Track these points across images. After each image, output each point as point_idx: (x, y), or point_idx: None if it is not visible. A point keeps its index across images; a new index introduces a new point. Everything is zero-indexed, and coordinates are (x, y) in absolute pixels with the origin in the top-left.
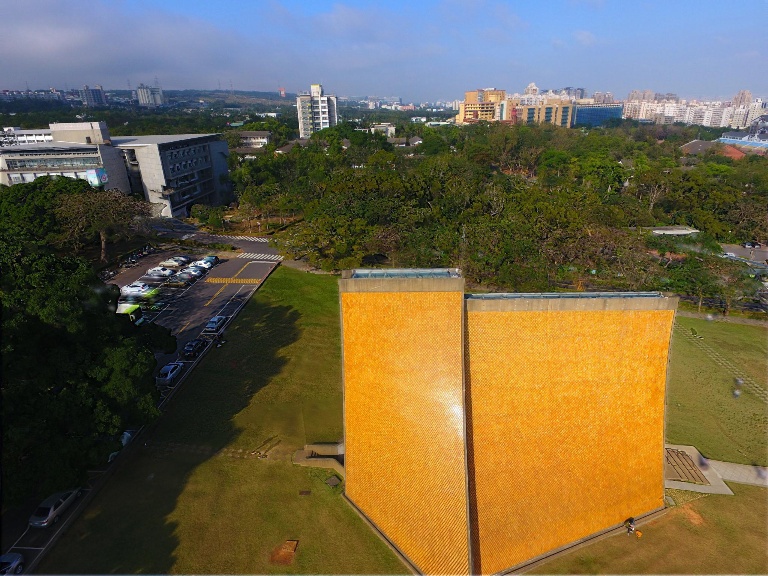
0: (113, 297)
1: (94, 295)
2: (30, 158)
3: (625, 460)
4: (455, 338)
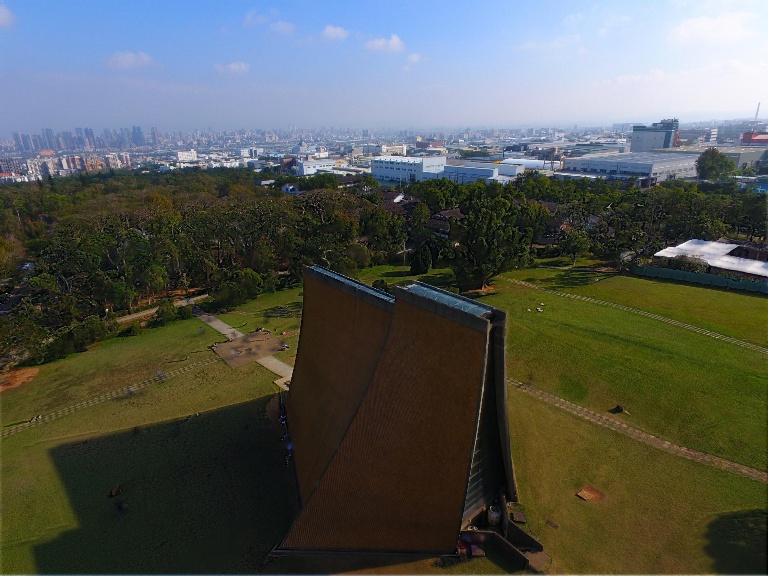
0: None
1: None
2: None
3: None
4: None
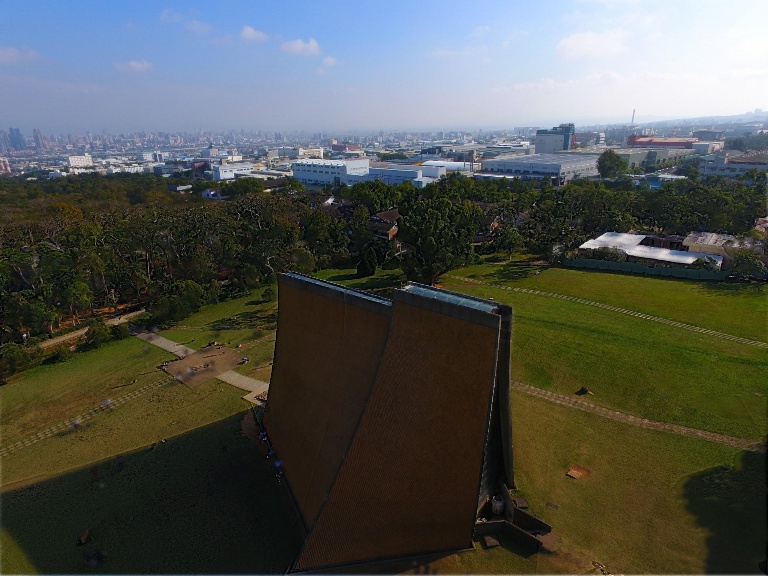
0: None
1: None
2: None
3: None
4: None
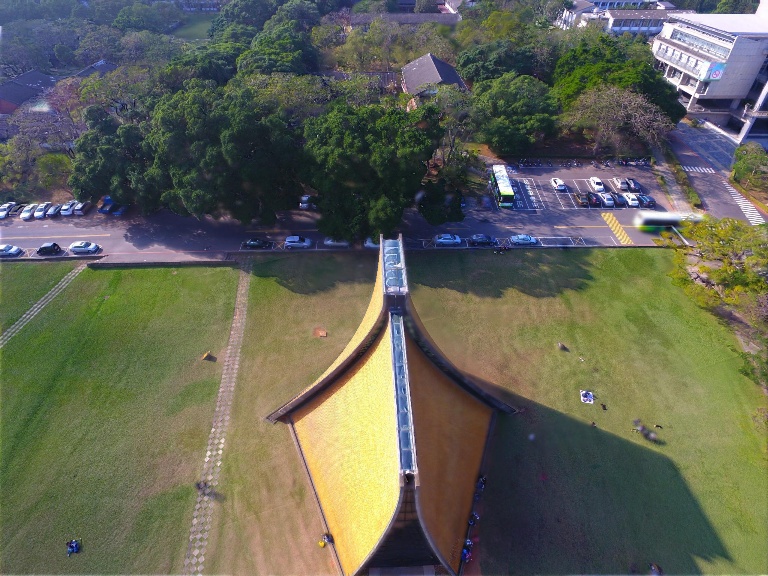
0: (417, 172)
1: (403, 165)
2: (688, 33)
3: (353, 518)
4: (371, 324)
